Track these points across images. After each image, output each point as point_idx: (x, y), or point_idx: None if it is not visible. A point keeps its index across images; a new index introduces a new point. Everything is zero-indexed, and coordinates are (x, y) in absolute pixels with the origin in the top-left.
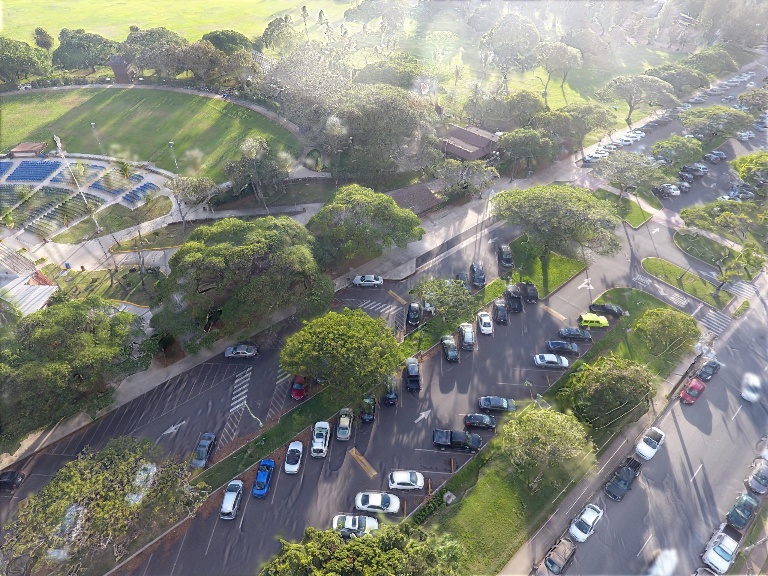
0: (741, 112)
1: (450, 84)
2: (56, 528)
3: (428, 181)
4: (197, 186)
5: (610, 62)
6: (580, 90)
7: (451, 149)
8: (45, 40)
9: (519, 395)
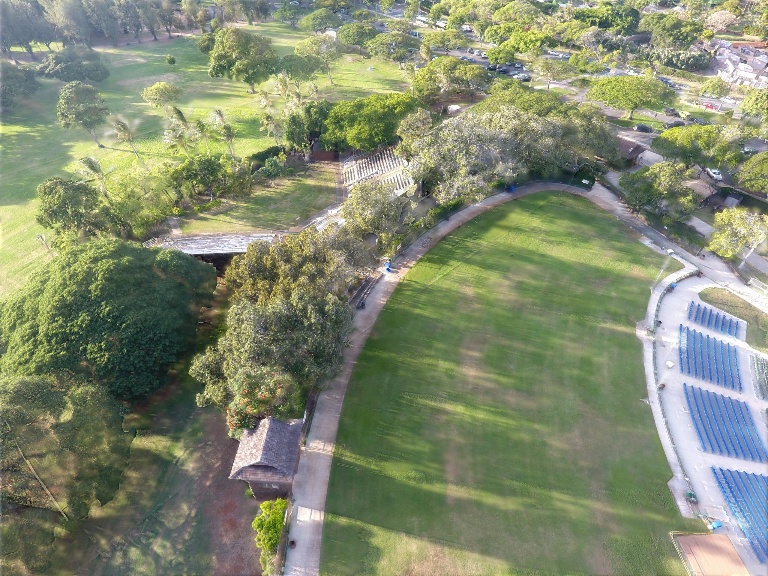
0: (454, 29)
1: None
2: None
3: None
4: None
5: None
6: (327, 72)
7: None
8: None
9: None
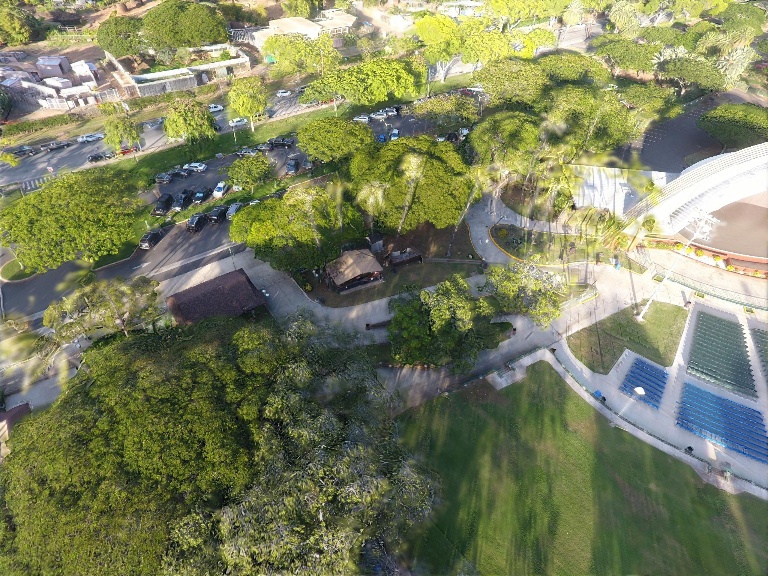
0: None
1: None
2: (454, 98)
3: None
4: None
5: None
6: None
7: None
8: None
9: (231, 159)
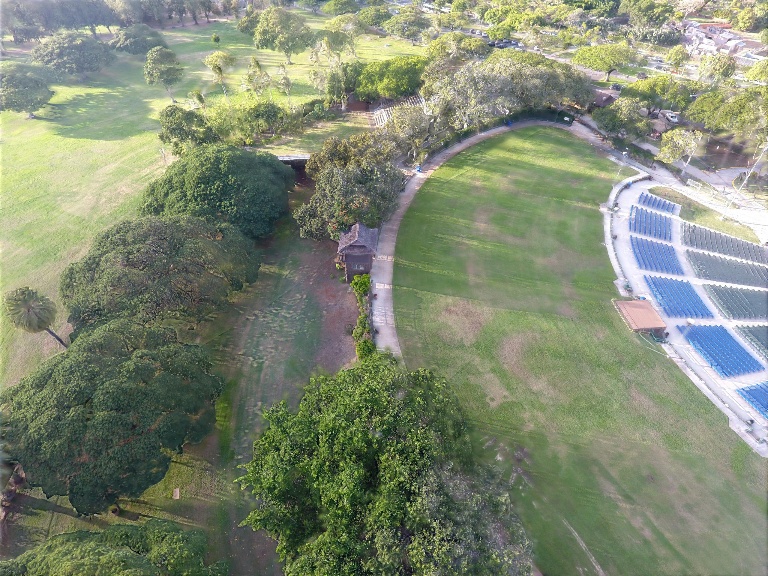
0: None
1: None
2: None
3: None
4: None
5: None
6: None
7: None
8: None
9: None
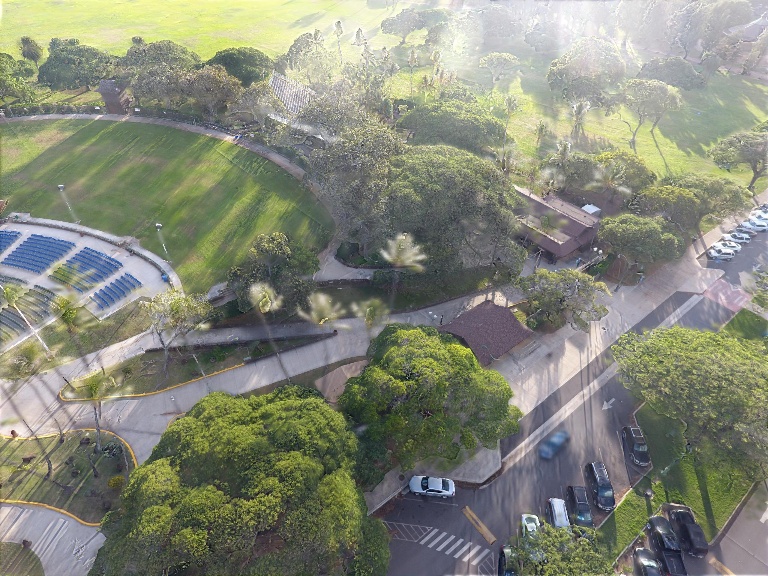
0: None
1: (512, 123)
2: None
3: (502, 284)
4: (185, 311)
5: (703, 98)
6: (675, 138)
7: (532, 236)
8: (32, 51)
9: None
